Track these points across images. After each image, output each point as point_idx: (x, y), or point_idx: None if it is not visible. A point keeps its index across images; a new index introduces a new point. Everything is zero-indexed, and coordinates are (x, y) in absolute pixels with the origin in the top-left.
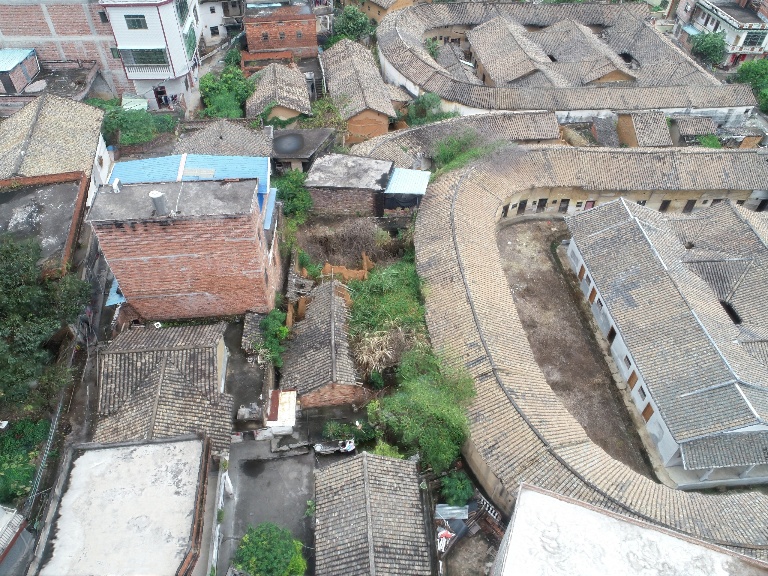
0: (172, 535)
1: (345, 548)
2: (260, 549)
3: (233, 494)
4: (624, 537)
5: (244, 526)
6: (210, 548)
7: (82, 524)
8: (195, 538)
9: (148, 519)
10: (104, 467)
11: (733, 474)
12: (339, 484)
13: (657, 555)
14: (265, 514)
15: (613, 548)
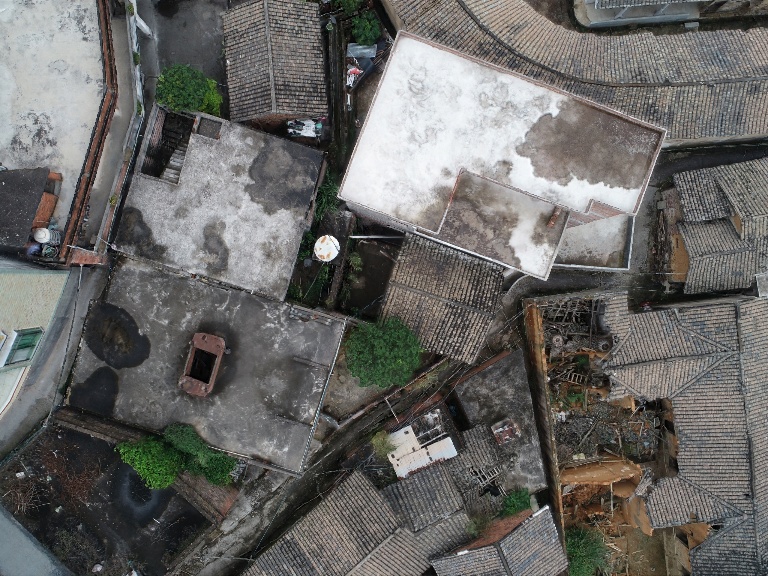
0: (90, 77)
1: (252, 86)
2: (175, 87)
3: (152, 35)
4: (481, 80)
5: (168, 64)
6: (133, 86)
7: (9, 67)
8: (110, 80)
9: (65, 63)
10: (9, 13)
11: (650, 11)
12: (244, 27)
13: (505, 95)
14: (185, 53)
15: (469, 89)
